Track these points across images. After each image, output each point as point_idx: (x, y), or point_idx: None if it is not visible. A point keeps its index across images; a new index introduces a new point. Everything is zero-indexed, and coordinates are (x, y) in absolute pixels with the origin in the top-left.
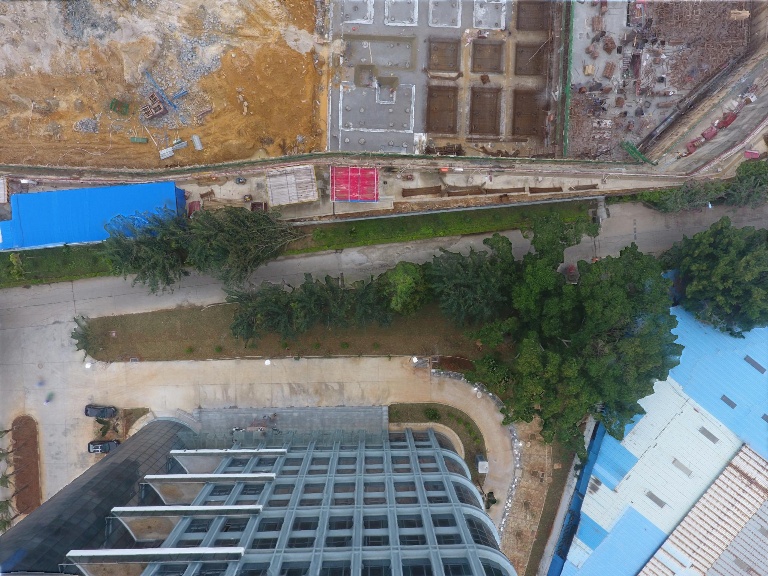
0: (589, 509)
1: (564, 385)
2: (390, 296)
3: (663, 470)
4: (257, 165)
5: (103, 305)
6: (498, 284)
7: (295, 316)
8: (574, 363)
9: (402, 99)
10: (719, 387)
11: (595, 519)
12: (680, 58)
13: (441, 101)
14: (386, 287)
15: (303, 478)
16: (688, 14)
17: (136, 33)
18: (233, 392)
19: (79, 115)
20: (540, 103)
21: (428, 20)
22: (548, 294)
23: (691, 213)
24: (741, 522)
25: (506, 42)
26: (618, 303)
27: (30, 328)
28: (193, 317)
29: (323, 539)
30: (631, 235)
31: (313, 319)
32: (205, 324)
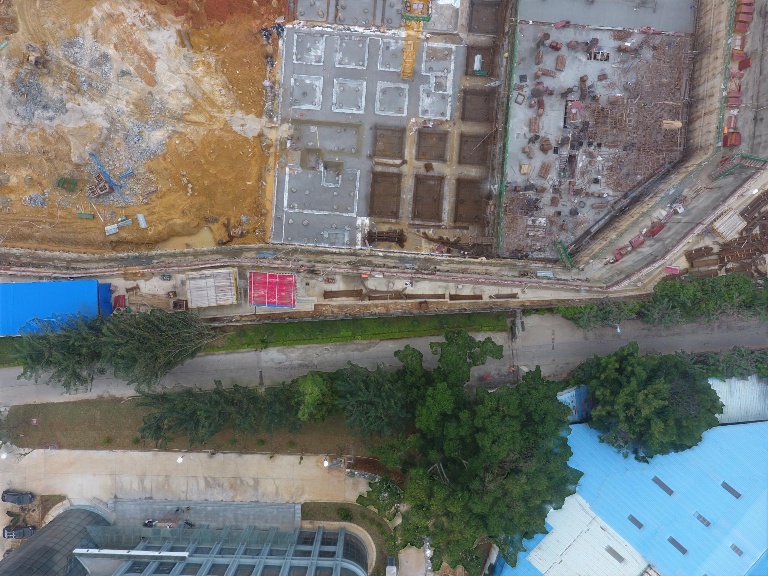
0: None
1: (449, 519)
2: (299, 404)
3: None
4: (189, 256)
5: (26, 393)
6: (401, 402)
7: (201, 424)
8: (459, 498)
9: (347, 183)
10: (626, 506)
11: None
12: (616, 160)
13: (385, 186)
14: (296, 395)
15: None
16: (621, 122)
17: (86, 115)
18: (149, 483)
19: (28, 190)
20: (483, 192)
21: (375, 108)
22: None
23: None
24: None
25: (451, 132)
26: (507, 439)
27: None
28: (113, 408)
29: None
30: (549, 345)
31: (221, 425)
32: (124, 416)
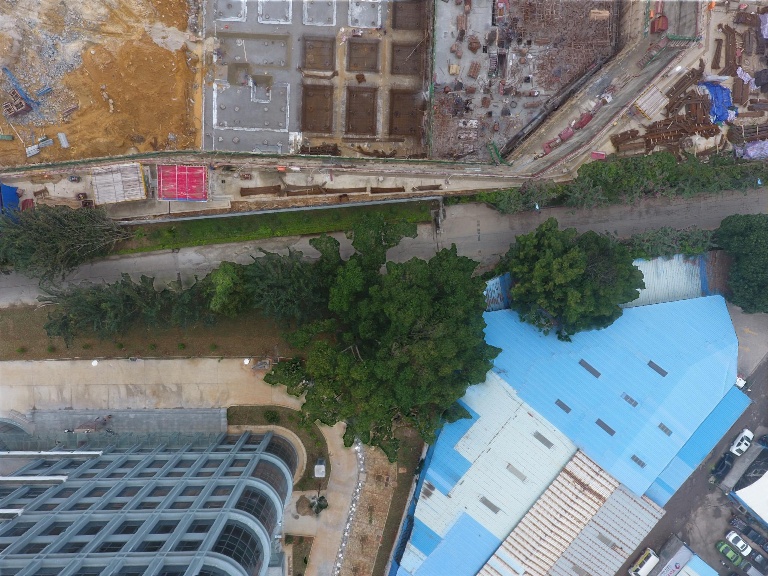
0: (422, 514)
1: (355, 388)
2: (212, 296)
3: (497, 475)
4: None
5: None
6: (313, 285)
7: (108, 316)
8: (364, 366)
9: (277, 98)
10: (554, 391)
11: (429, 525)
12: (547, 58)
13: (317, 100)
14: (208, 287)
15: (94, 481)
16: (548, 13)
17: None
18: (68, 393)
19: None
20: (418, 103)
21: (302, 18)
22: (365, 295)
23: (536, 214)
24: (576, 529)
25: (382, 41)
26: (413, 305)
27: None
28: (26, 317)
29: (56, 545)
30: (475, 236)
31: (131, 319)
32: (38, 324)
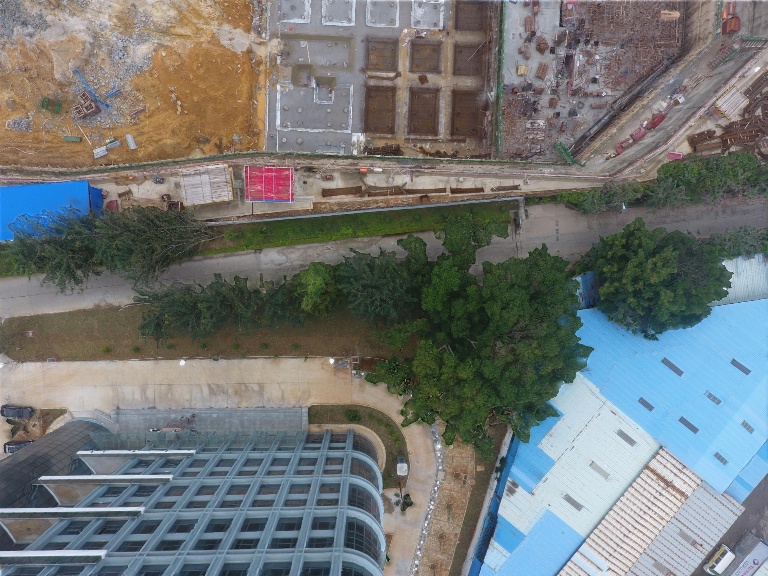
0: (506, 512)
1: (461, 387)
2: (302, 297)
3: (580, 473)
4: (182, 164)
5: (20, 305)
6: (406, 285)
7: (203, 316)
8: (470, 365)
9: (340, 99)
10: (637, 389)
11: (512, 522)
12: (614, 59)
13: (380, 101)
14: (298, 288)
15: (200, 480)
16: (618, 15)
17: (67, 31)
18: (152, 393)
19: (12, 114)
20: (479, 103)
21: (366, 20)
22: (457, 295)
23: (614, 214)
24: (659, 525)
25: (444, 42)
26: (516, 305)
27: None
28: (110, 317)
29: (192, 542)
30: (553, 236)
31: (223, 319)
32: (123, 324)
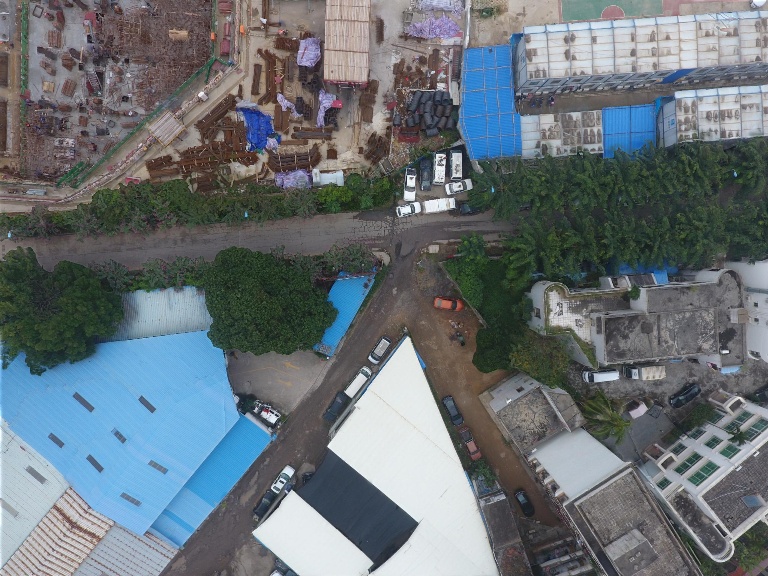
0: None
1: None
2: None
3: None
4: None
5: None
6: None
7: None
8: None
9: None
10: (47, 425)
11: None
12: (146, 77)
13: None
14: None
15: None
16: (128, 32)
17: None
18: None
19: None
20: None
21: None
22: None
23: (65, 240)
24: (69, 567)
25: (10, 54)
26: None
27: None
28: None
29: None
30: None
31: None
32: None
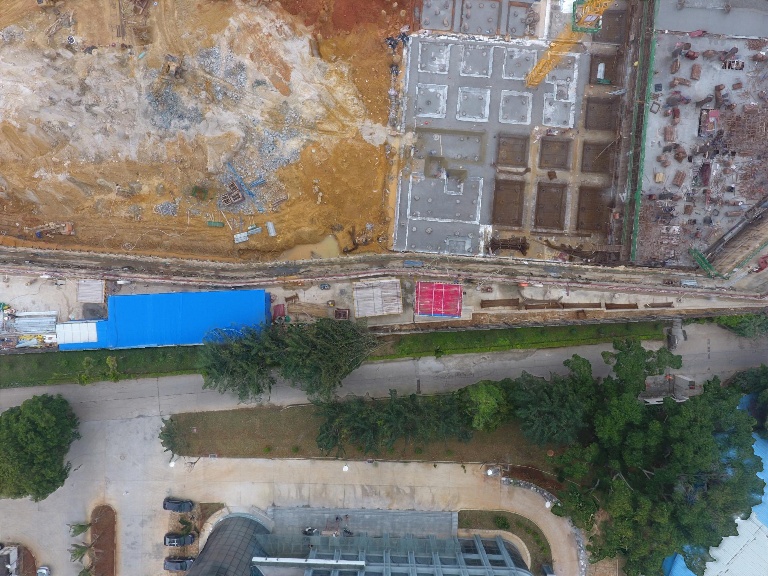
0: None
1: (653, 529)
2: (471, 414)
3: None
4: (336, 264)
5: (186, 401)
6: (581, 412)
7: (380, 433)
8: (664, 509)
9: (469, 191)
10: None
11: None
12: (750, 169)
13: (507, 194)
14: (467, 404)
15: None
16: (761, 131)
17: (220, 125)
18: (307, 491)
19: (160, 198)
20: (605, 199)
21: (499, 116)
22: None
23: None
24: None
25: (574, 140)
26: (708, 449)
27: (115, 421)
28: (272, 417)
29: None
30: (705, 354)
31: None
32: (283, 424)
